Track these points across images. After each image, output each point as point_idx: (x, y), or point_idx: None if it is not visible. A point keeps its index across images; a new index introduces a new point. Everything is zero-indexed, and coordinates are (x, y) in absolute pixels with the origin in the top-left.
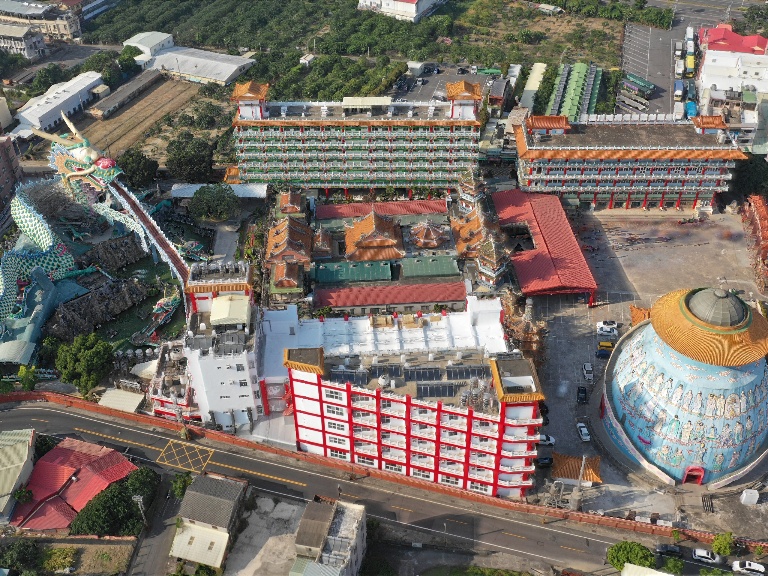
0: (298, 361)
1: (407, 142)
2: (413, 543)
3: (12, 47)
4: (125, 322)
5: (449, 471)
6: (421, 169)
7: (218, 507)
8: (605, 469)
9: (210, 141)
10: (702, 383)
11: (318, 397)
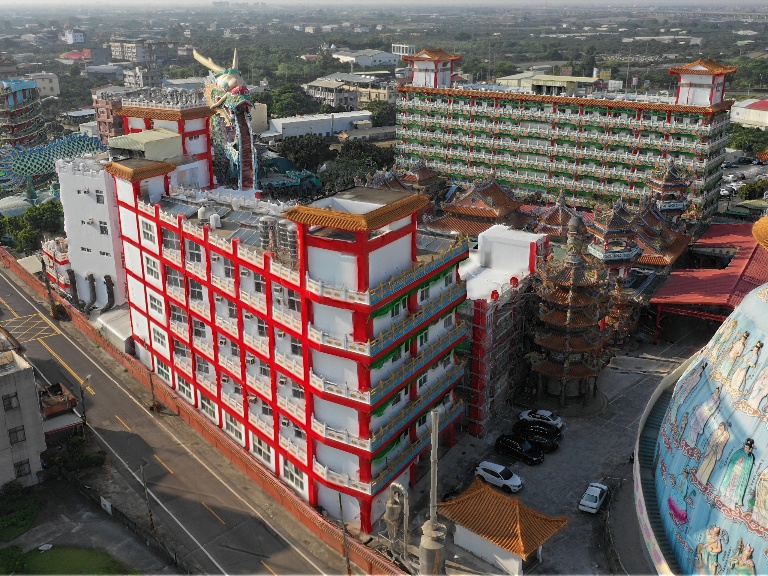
0: None
1: (601, 133)
2: (102, 498)
3: (325, 98)
4: None
5: (259, 424)
6: (616, 178)
7: None
8: (581, 566)
9: None
10: None
11: (138, 238)
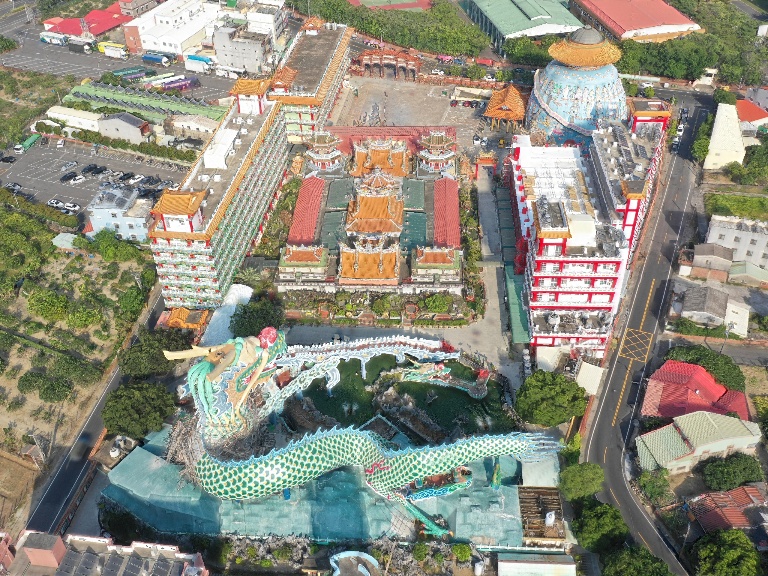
0: (642, 189)
1: None
2: None
3: None
4: (435, 417)
5: None
6: None
7: (715, 295)
8: None
9: None
10: (615, 74)
11: None
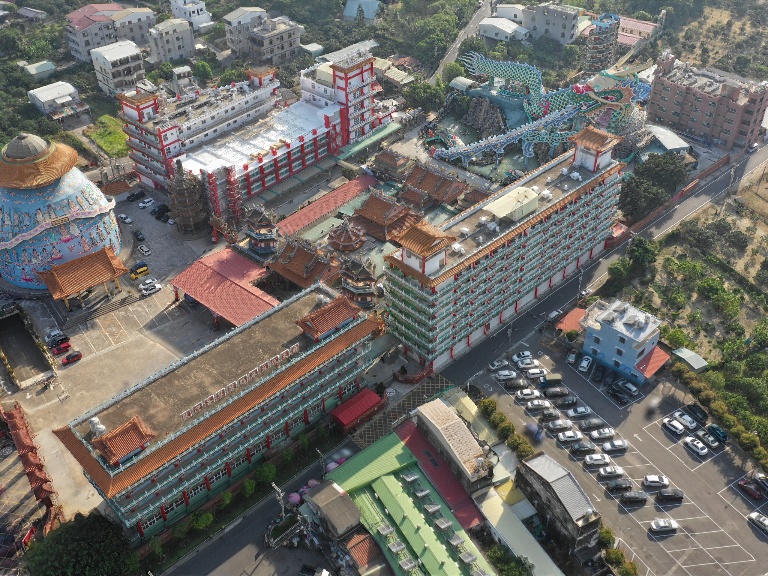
0: (262, 67)
1: None
2: None
3: None
4: (474, 143)
5: None
6: None
7: None
8: None
9: (725, 258)
10: None
11: None
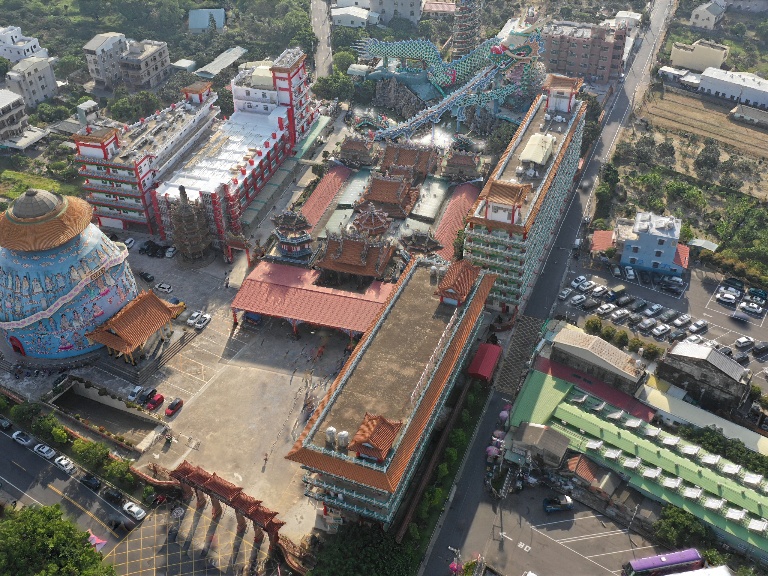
0: (196, 83)
1: None
2: None
3: None
4: None
5: None
6: None
7: None
8: None
9: (665, 166)
10: None
11: None
